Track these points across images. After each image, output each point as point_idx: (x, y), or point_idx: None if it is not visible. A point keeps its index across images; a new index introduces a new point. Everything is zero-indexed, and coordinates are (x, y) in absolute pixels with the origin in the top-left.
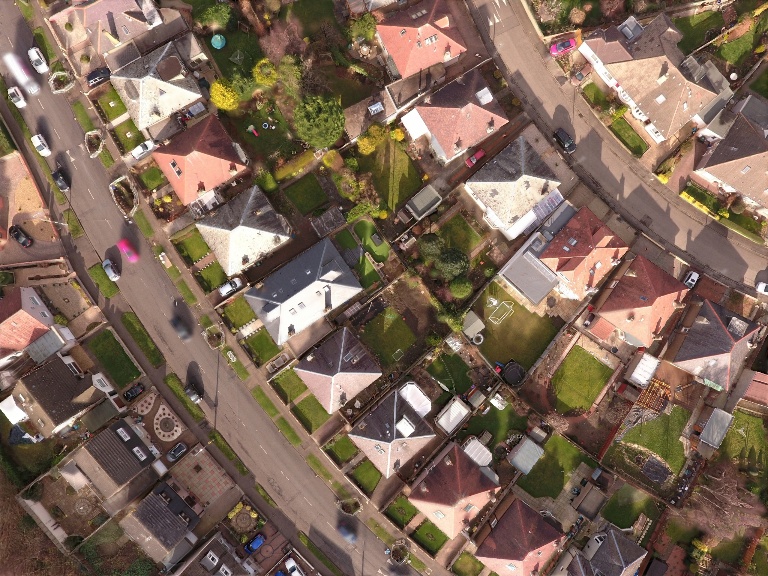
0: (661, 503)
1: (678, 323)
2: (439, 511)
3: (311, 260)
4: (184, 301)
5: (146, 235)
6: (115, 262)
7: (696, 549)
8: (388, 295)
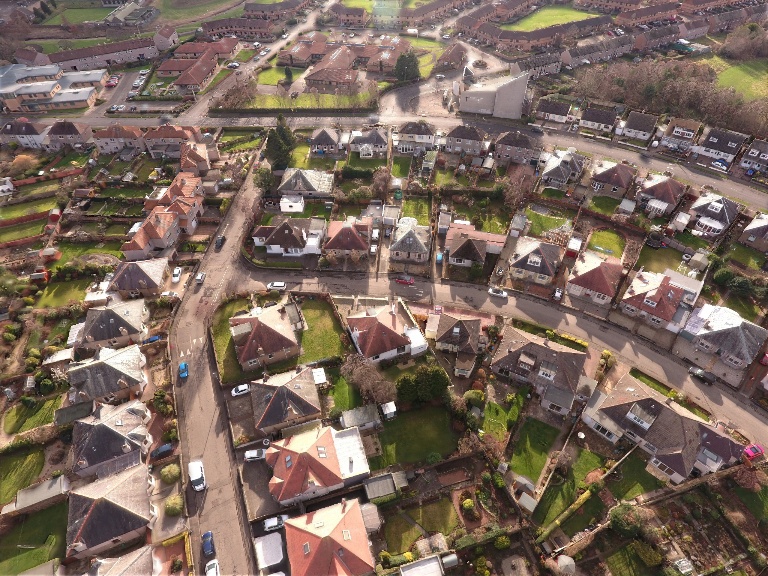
0: None
1: (558, 271)
2: None
3: None
4: None
5: None
6: None
7: (509, 181)
8: (764, 275)
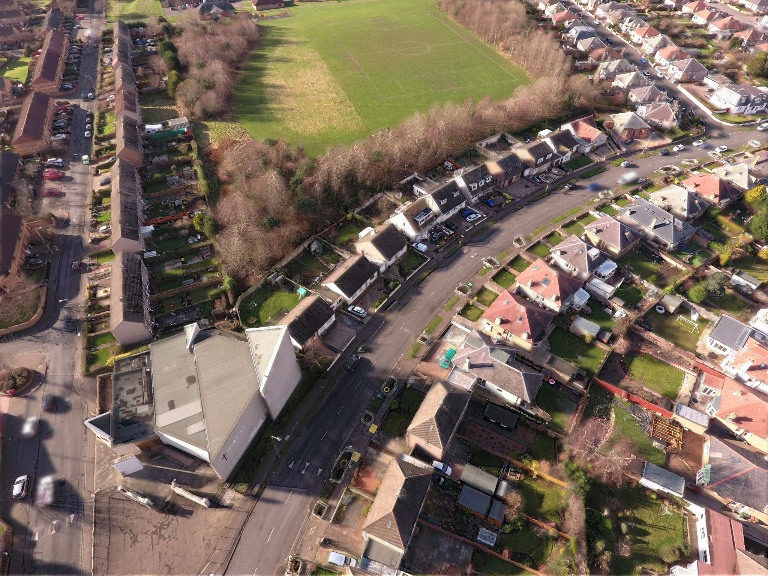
0: None
1: None
2: (540, 267)
3: None
4: (621, 186)
5: (651, 176)
6: (631, 166)
7: None
8: (668, 265)
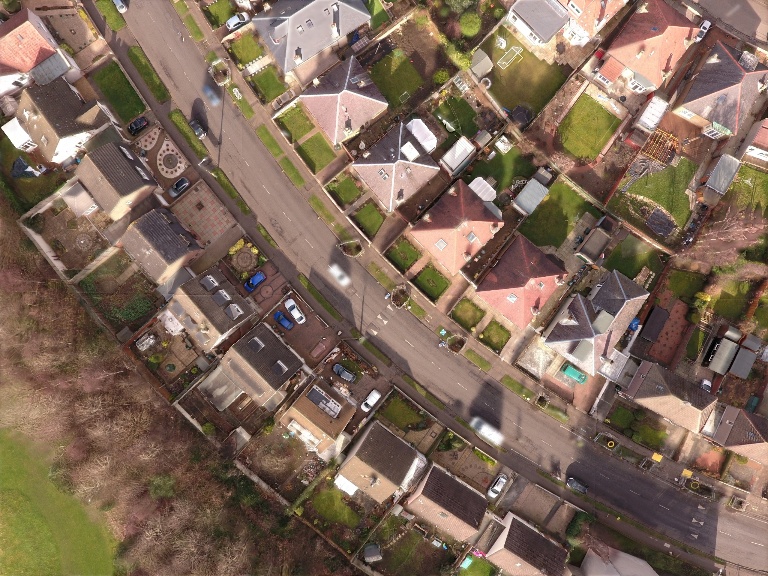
0: (665, 254)
1: (688, 72)
2: (441, 239)
3: None
4: (191, 37)
5: None
6: None
7: (698, 299)
8: (396, 36)
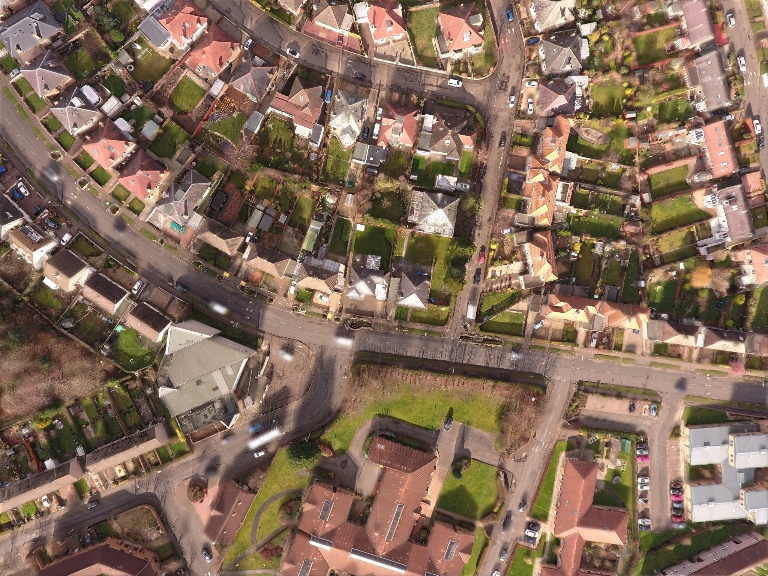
0: None
1: None
2: (94, 149)
3: (29, 9)
4: None
5: None
6: None
7: (243, 188)
8: (81, 40)
